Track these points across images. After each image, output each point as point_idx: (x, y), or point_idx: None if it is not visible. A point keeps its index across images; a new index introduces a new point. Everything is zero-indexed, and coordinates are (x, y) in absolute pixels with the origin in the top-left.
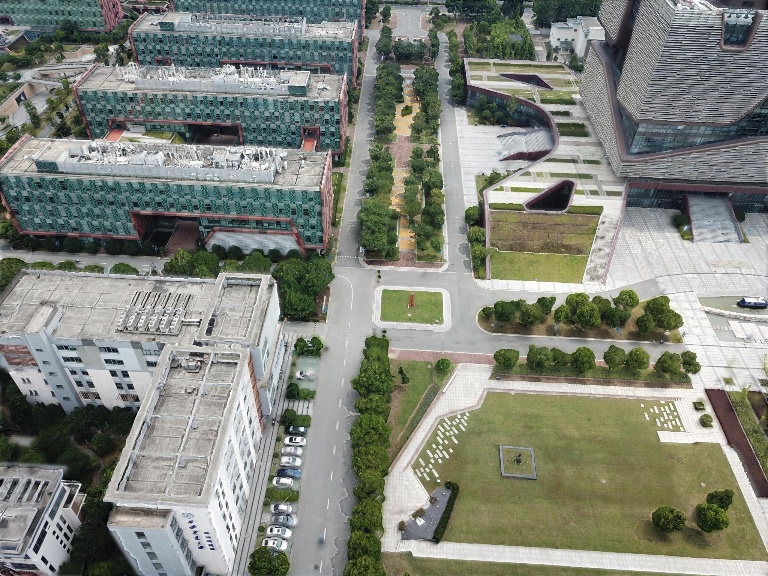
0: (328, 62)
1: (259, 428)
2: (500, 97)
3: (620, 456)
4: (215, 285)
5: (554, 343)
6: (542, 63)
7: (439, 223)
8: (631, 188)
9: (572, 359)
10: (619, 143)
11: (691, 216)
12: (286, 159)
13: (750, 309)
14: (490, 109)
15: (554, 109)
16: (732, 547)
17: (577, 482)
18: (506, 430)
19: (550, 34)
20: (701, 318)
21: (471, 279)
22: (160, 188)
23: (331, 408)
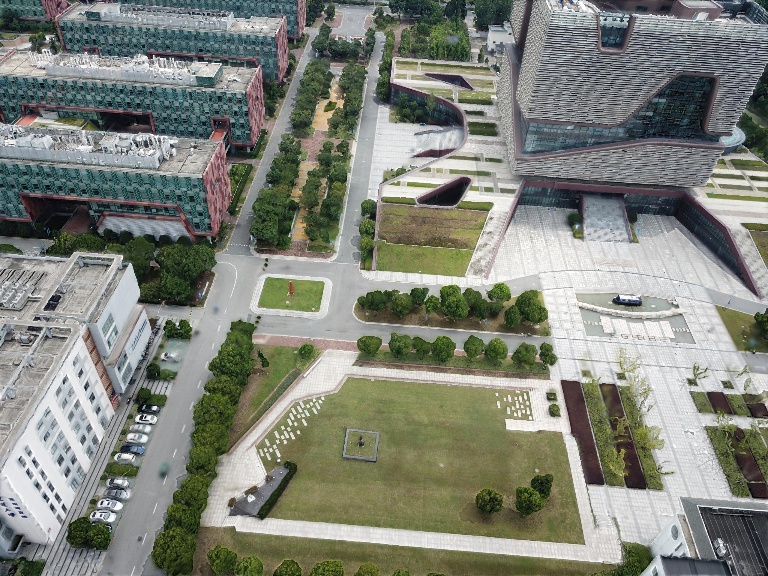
0: (253, 56)
1: (109, 405)
2: (420, 96)
3: (463, 442)
4: (66, 263)
5: (424, 333)
6: (469, 64)
7: (332, 215)
8: (528, 186)
9: (432, 348)
10: (515, 142)
11: (585, 215)
12: (177, 147)
13: (625, 306)
14: (411, 107)
15: (470, 109)
16: (550, 530)
17: (415, 465)
18: (357, 414)
19: (487, 37)
20: (574, 313)
21: (357, 270)
22: (46, 171)
23: (189, 389)
